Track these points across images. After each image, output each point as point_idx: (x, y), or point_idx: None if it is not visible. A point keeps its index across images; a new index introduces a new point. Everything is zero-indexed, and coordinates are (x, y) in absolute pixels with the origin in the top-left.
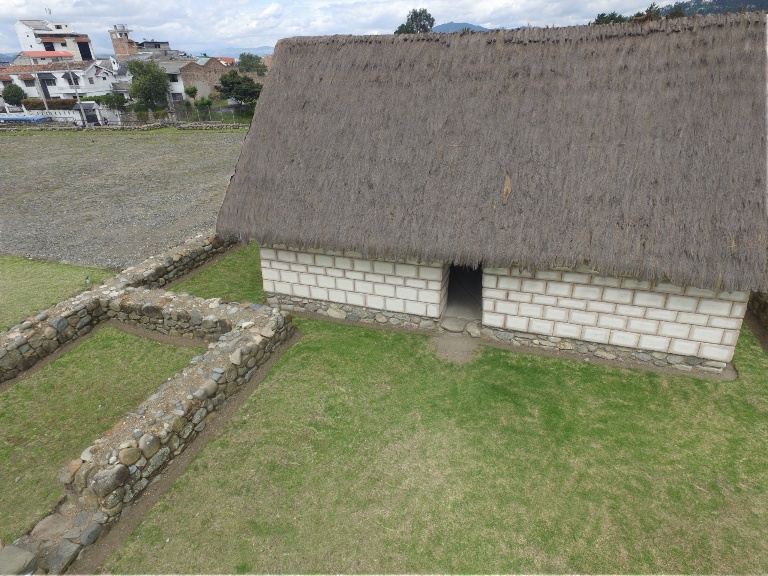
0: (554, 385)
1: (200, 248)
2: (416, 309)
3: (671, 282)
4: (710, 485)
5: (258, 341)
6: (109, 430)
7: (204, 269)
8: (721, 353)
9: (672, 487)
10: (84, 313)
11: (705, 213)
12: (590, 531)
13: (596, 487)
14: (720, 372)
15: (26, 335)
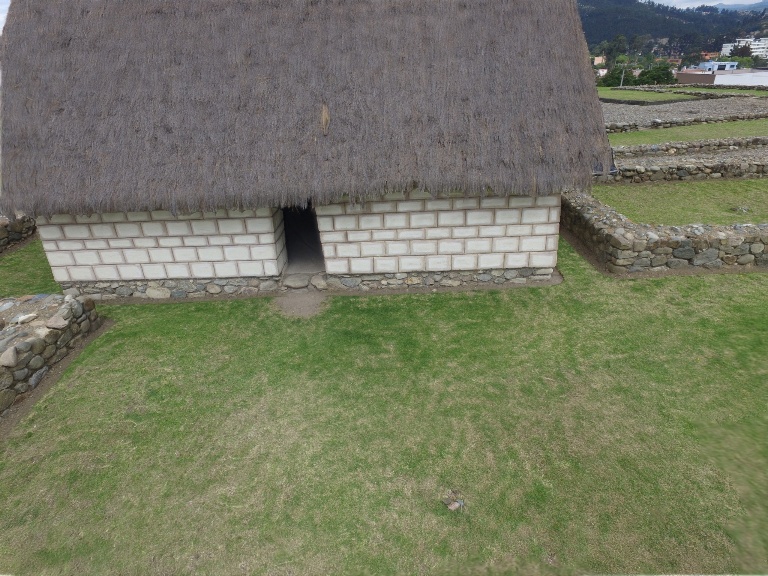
0: (406, 319)
1: None
2: (251, 270)
3: (496, 196)
4: (555, 374)
5: (43, 334)
6: None
7: None
8: (547, 259)
9: (524, 384)
10: None
11: (514, 124)
12: (456, 444)
13: (457, 402)
14: (549, 278)
15: None
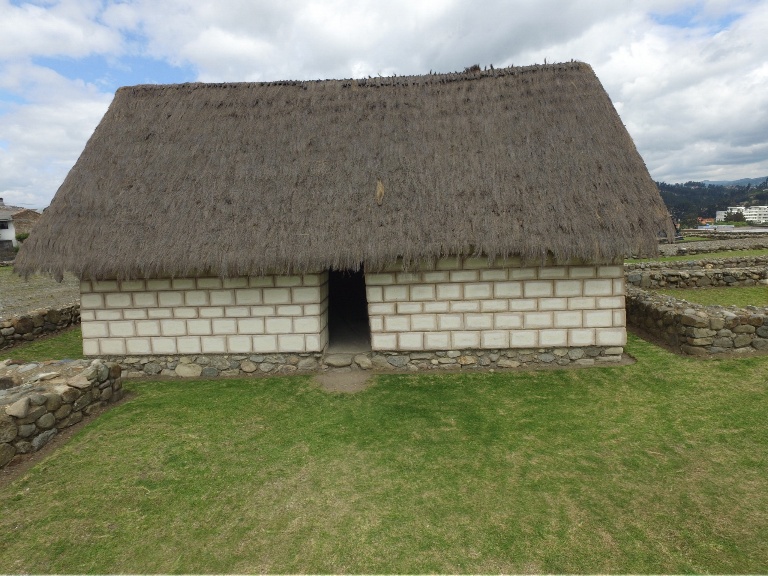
0: (465, 395)
1: None
2: (292, 344)
3: (554, 266)
4: (661, 447)
5: (62, 391)
6: None
7: None
8: (616, 336)
9: (625, 457)
10: None
11: (567, 196)
12: (557, 523)
13: (545, 476)
14: (620, 359)
15: None
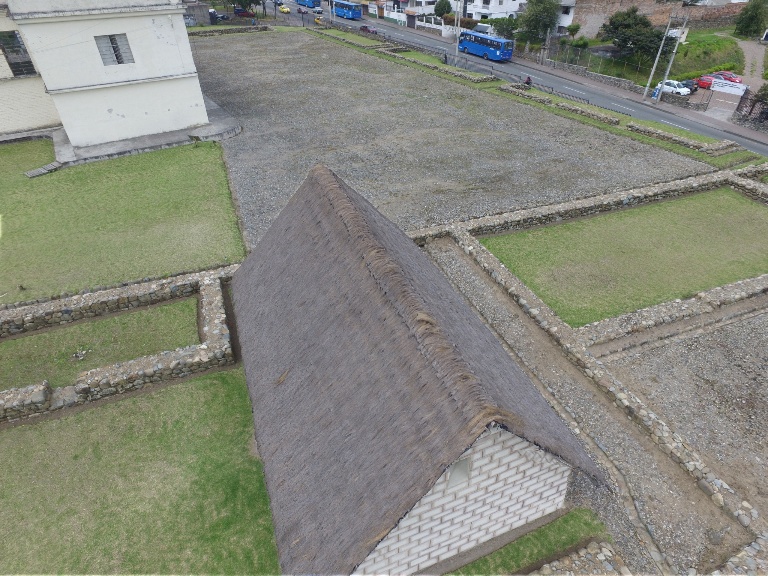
0: (254, 513)
1: None
2: None
3: None
4: None
5: (195, 361)
6: (104, 367)
7: None
8: None
9: None
10: (189, 286)
11: (308, 505)
12: None
13: (171, 570)
14: None
15: (156, 289)
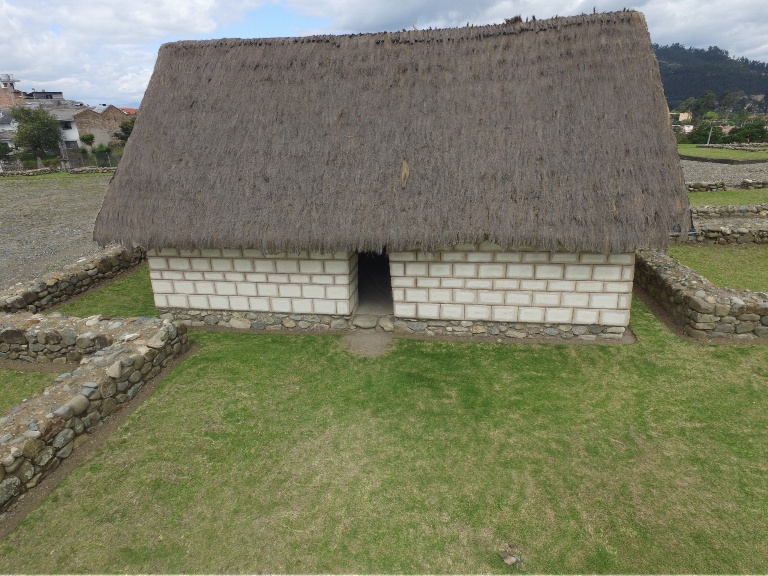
0: (470, 367)
1: (82, 272)
2: (325, 308)
3: (566, 252)
4: (624, 437)
5: (143, 353)
6: None
7: (87, 295)
8: (619, 318)
9: (589, 444)
10: None
11: (587, 183)
12: (515, 498)
13: (517, 455)
14: (620, 338)
15: None
